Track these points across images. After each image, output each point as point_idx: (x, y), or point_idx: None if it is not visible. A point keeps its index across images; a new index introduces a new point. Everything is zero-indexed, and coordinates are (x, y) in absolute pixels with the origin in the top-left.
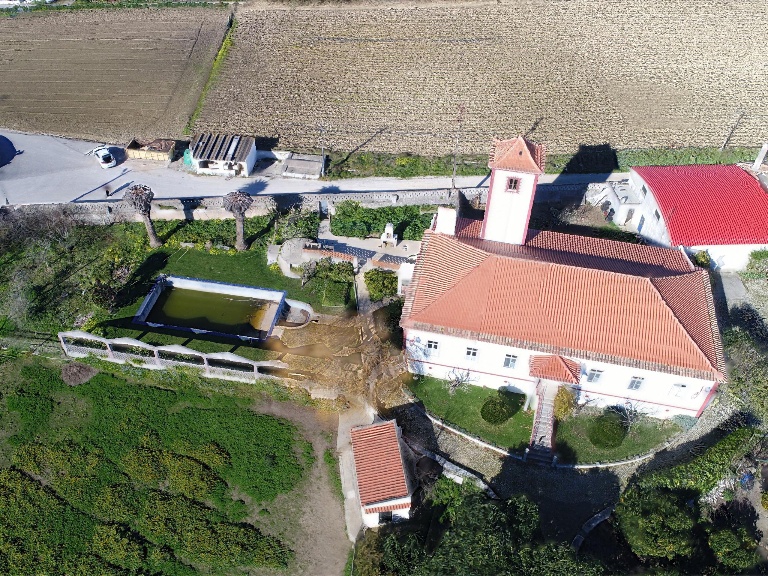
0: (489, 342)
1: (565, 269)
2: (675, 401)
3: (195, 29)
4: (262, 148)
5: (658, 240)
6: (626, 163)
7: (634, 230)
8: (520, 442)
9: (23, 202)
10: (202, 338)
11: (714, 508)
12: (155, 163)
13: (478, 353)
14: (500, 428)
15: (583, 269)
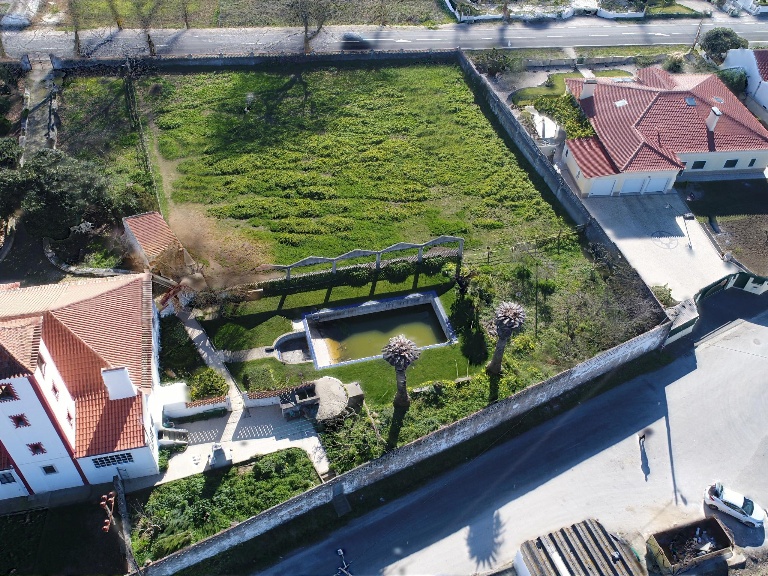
0: (59, 284)
1: None
2: None
3: None
4: None
5: None
6: None
7: None
8: None
9: (712, 389)
10: (363, 298)
11: None
12: None
13: None
14: None
15: None
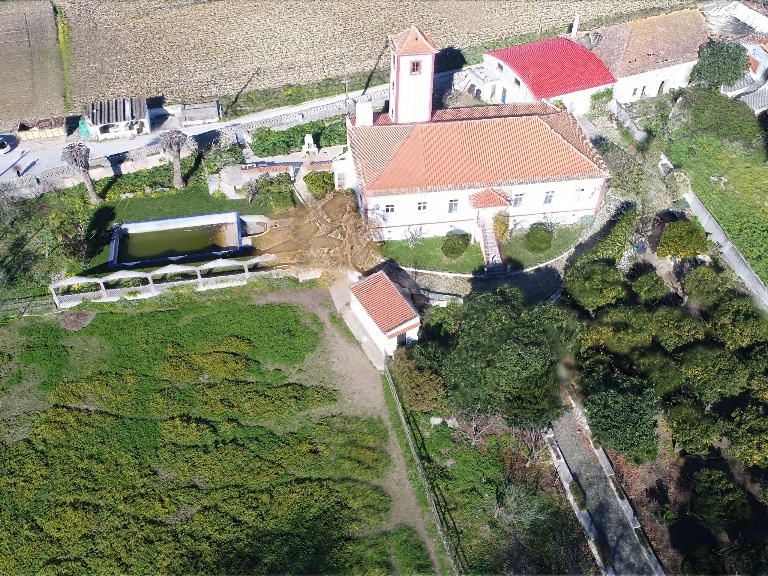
0: (436, 192)
1: (475, 123)
2: (578, 205)
3: (20, 21)
4: (152, 107)
5: (523, 102)
6: (471, 58)
7: (499, 102)
8: (478, 266)
9: None
10: (181, 262)
11: (626, 271)
12: (51, 140)
13: (427, 206)
14: (459, 261)
15: (489, 120)
